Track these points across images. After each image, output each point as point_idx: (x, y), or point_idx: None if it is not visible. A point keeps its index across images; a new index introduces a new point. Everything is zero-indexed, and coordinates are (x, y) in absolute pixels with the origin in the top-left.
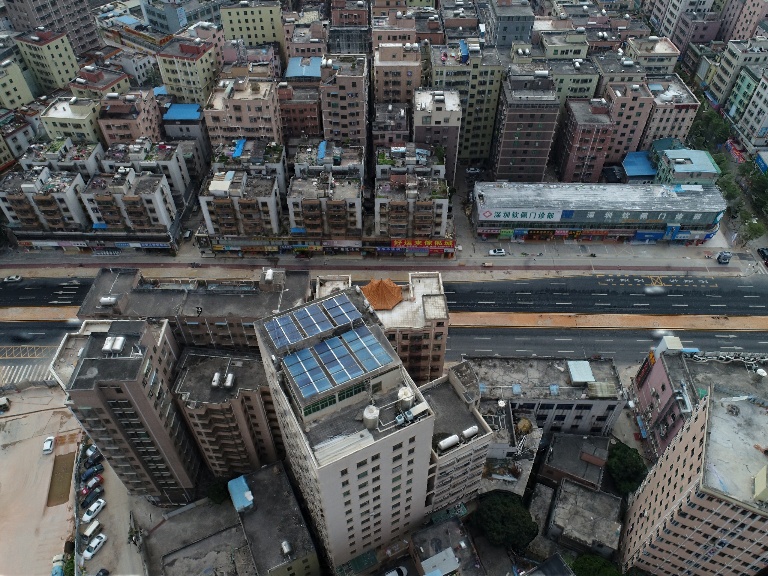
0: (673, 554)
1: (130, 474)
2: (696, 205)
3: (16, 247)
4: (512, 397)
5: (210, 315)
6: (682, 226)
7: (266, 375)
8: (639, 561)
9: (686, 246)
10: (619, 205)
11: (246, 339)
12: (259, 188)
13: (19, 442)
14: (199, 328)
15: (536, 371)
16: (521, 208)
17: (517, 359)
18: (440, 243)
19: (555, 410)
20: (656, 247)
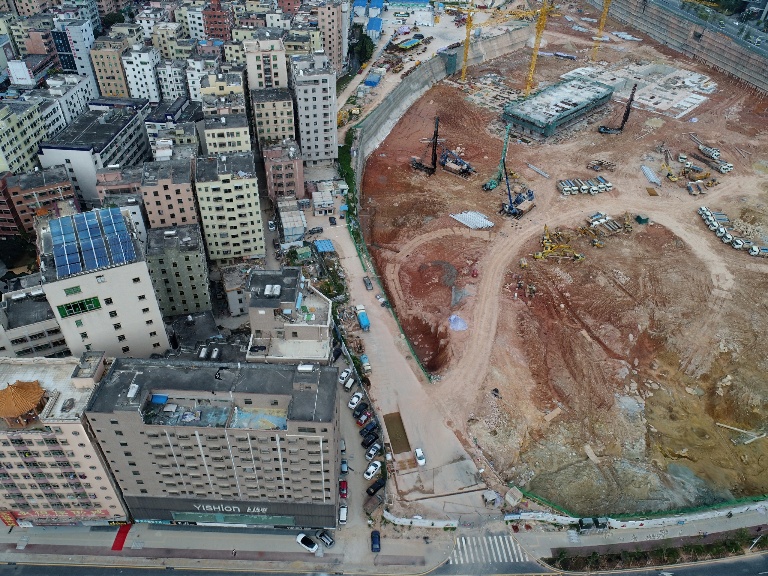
0: None
1: None
2: None
3: None
4: None
5: (207, 371)
6: None
7: None
8: None
9: None
10: None
11: None
12: None
13: (451, 462)
14: None
15: None
16: None
17: None
18: None
19: None
20: None
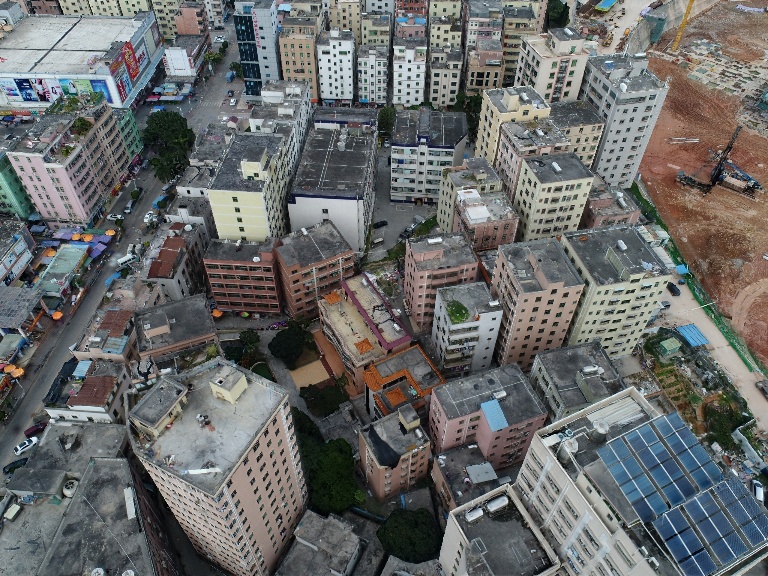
0: None
1: None
2: None
3: None
4: None
5: None
6: None
7: None
8: None
9: None
10: None
11: None
12: None
13: None
14: None
15: None
16: None
17: None
18: None
19: None
20: None
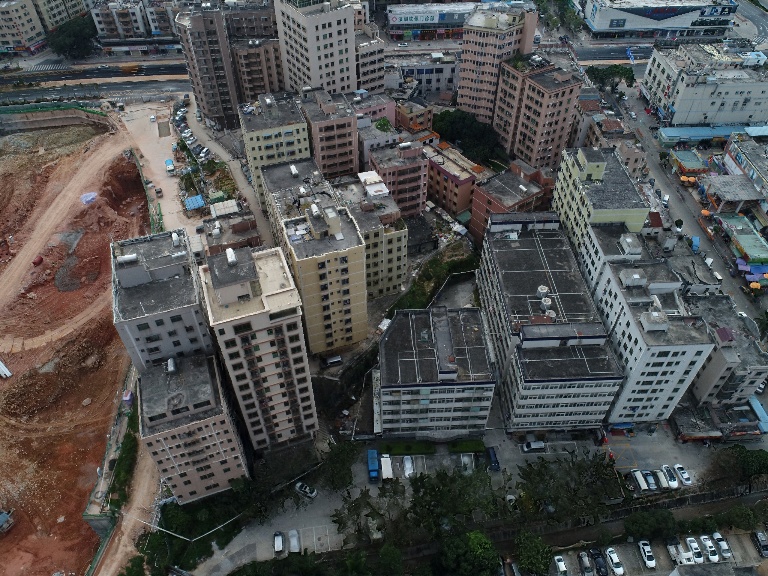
0: (467, 87)
1: (210, 93)
2: None
3: (99, 55)
4: (402, 67)
5: None
6: None
7: (277, 25)
8: (457, 105)
9: None
10: None
11: (263, 30)
12: (254, 3)
13: (135, 119)
14: (239, 23)
15: (415, 59)
16: (414, 14)
17: (405, 56)
18: None
19: (425, 75)
20: None
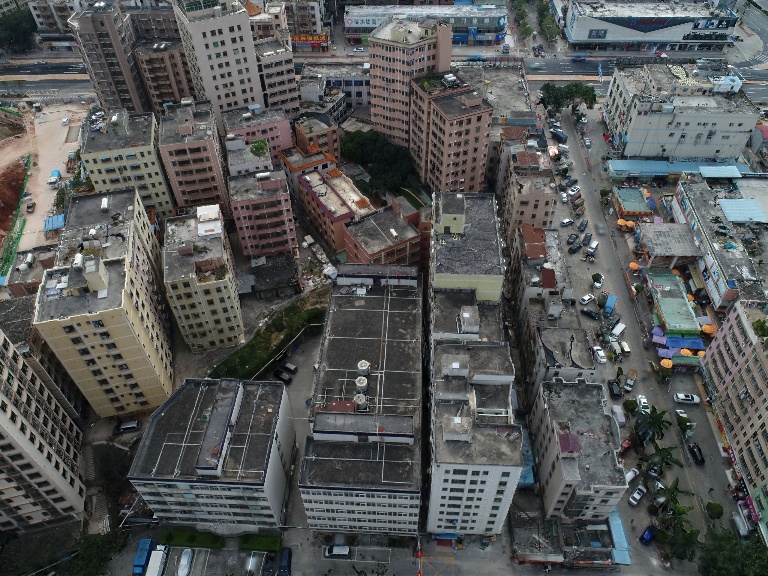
0: (380, 106)
1: (110, 99)
2: (487, 14)
3: (42, 50)
4: None
5: None
6: (479, 29)
7: None
8: (372, 125)
9: (486, 46)
10: (436, 15)
11: (174, 33)
12: None
13: (48, 121)
14: (147, 24)
15: (346, 69)
16: (371, 16)
17: (337, 65)
18: (317, 38)
19: (354, 87)
20: (466, 47)
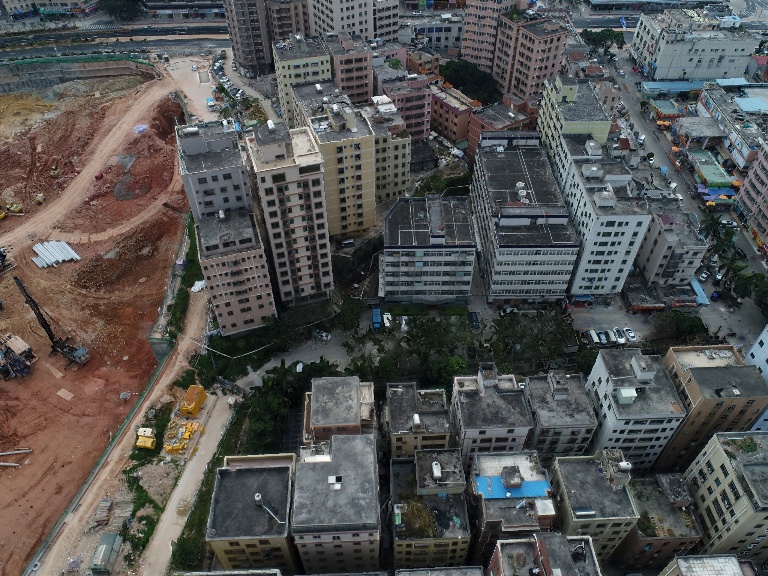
0: (470, 39)
1: (246, 42)
2: None
3: (146, 17)
4: None
5: None
6: None
7: None
8: (462, 56)
9: None
10: None
11: None
12: None
13: (179, 68)
14: None
15: (426, 19)
16: None
17: (418, 17)
18: None
19: (435, 33)
20: None
